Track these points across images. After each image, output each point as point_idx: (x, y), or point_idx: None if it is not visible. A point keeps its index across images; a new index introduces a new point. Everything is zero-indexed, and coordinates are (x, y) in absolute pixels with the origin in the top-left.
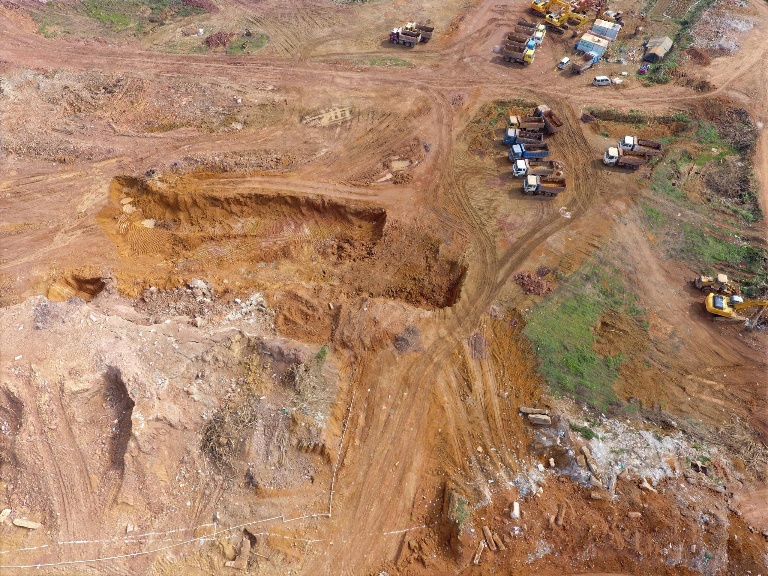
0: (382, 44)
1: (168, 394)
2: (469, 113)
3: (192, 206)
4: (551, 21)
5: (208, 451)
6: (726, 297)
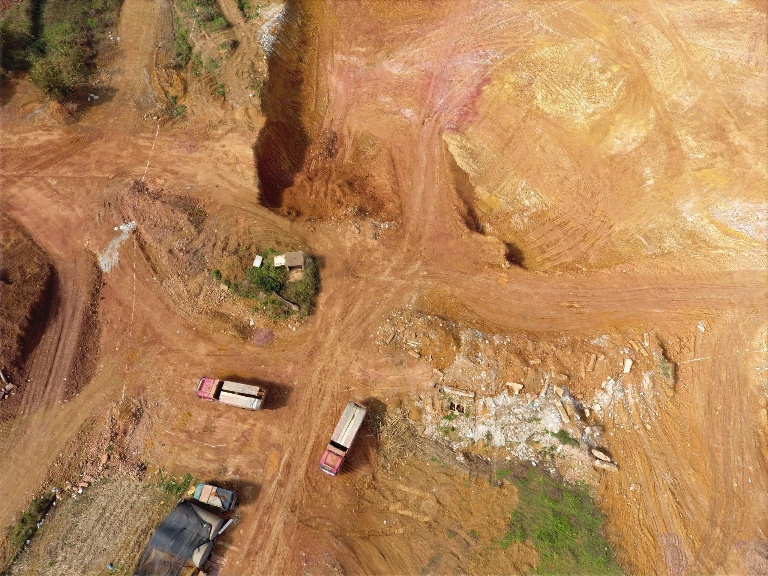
0: None
1: None
2: None
3: None
4: None
5: None
6: None
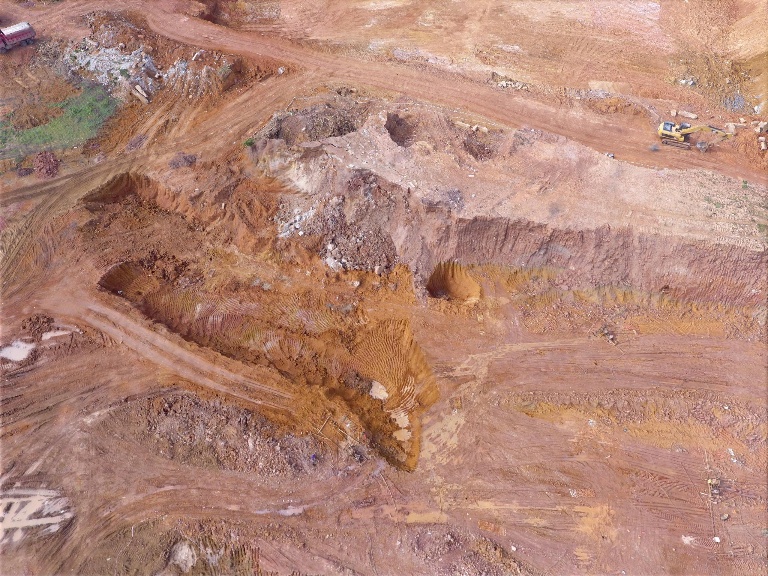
0: None
1: None
2: None
3: (316, 384)
4: None
5: None
6: None
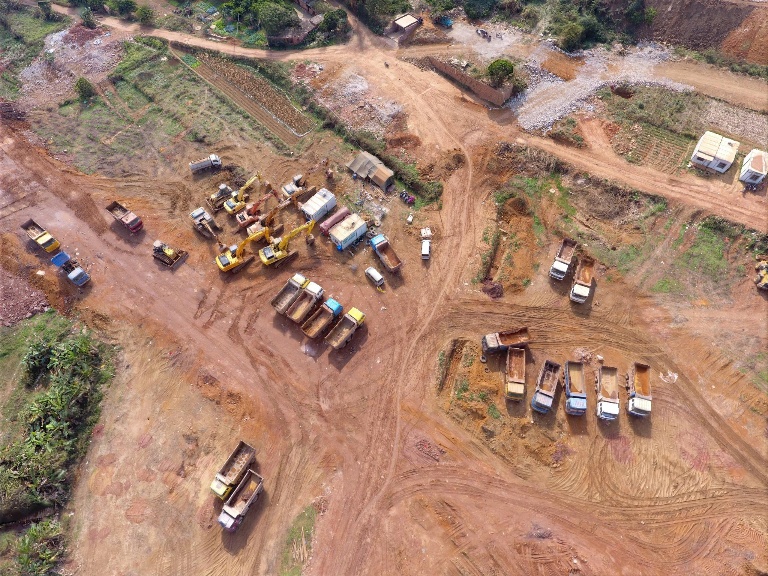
0: (233, 550)
1: None
2: (463, 441)
3: None
4: (276, 259)
5: None
6: None
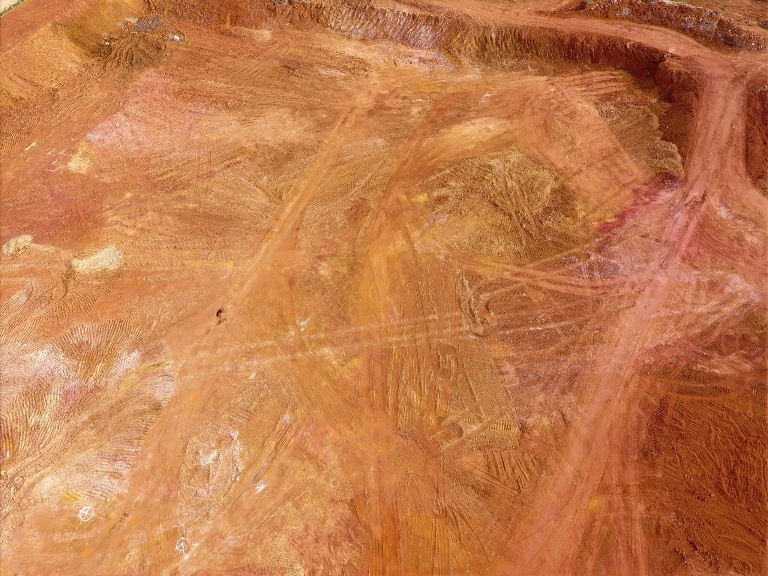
0: None
1: None
2: None
3: None
4: None
5: None
6: None
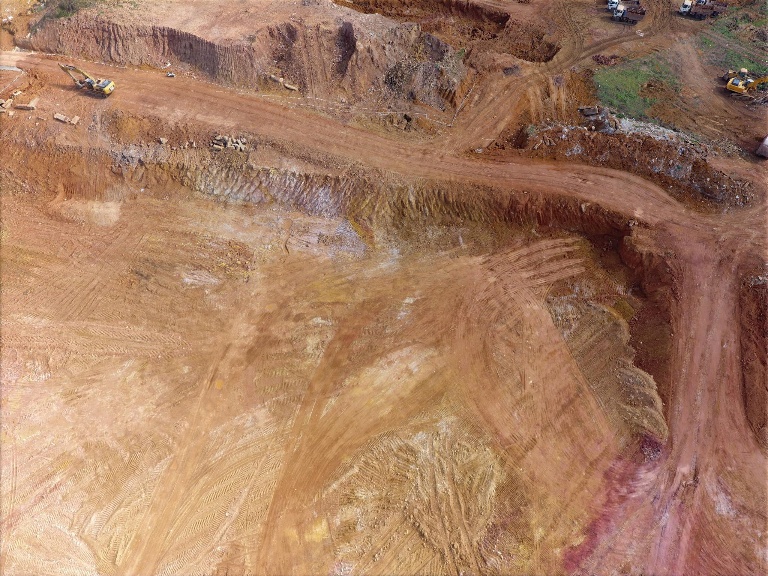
0: None
1: (374, 43)
2: None
3: None
4: None
5: (388, 82)
6: (743, 81)
